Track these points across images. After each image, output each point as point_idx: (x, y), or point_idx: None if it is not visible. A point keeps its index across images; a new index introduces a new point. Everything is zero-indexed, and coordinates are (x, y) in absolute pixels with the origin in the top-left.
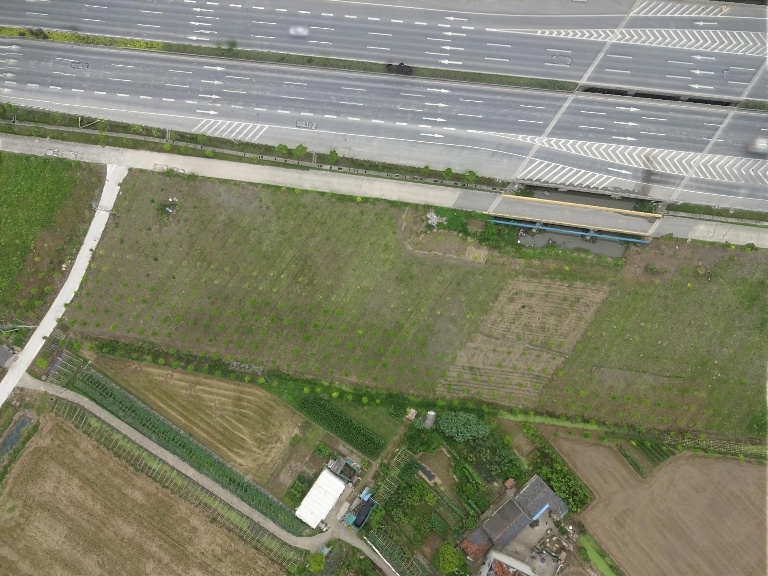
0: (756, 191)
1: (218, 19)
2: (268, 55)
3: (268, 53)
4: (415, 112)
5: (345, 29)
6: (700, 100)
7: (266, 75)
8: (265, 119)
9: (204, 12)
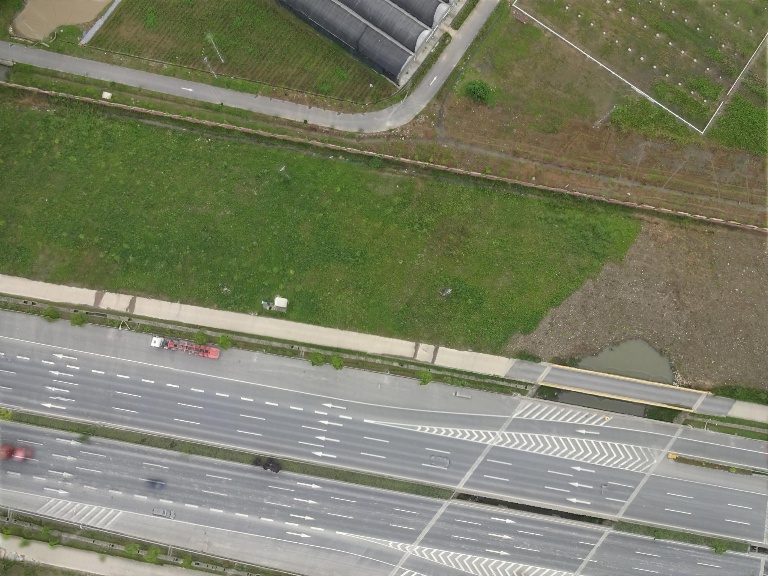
0: None
1: (77, 385)
2: (128, 435)
3: (128, 433)
4: (282, 507)
5: (215, 408)
6: (577, 515)
7: (125, 454)
8: (119, 503)
9: (63, 376)
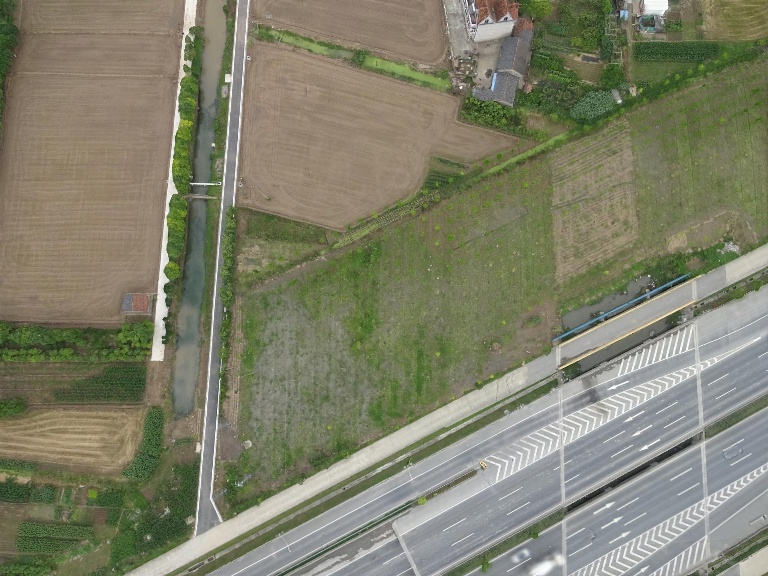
0: (498, 443)
1: None
2: None
3: None
4: None
5: None
6: (596, 495)
7: None
8: None
9: None
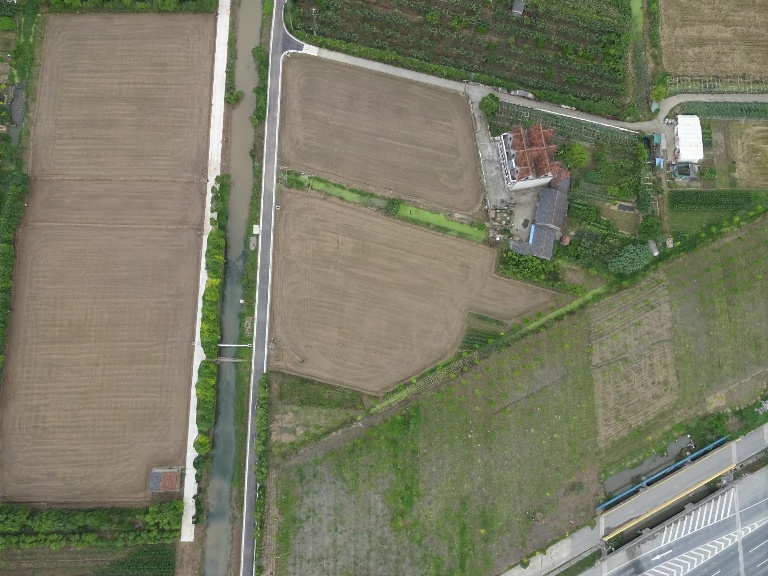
0: None
1: None
2: None
3: None
4: None
5: None
6: None
7: None
8: None
9: None
